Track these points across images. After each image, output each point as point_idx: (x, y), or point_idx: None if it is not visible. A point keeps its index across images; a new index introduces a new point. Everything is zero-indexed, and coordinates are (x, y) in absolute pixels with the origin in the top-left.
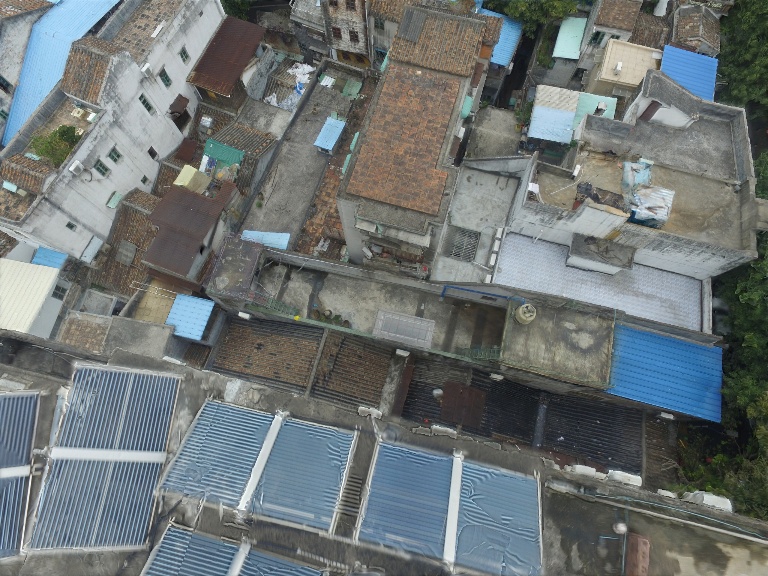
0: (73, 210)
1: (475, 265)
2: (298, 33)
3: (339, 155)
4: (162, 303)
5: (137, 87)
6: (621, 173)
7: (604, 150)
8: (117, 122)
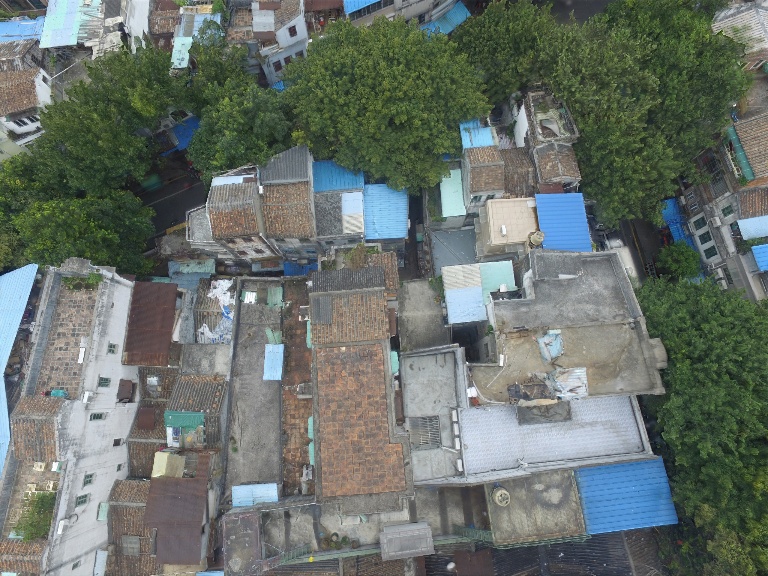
0: (73, 553)
1: (444, 450)
2: (203, 250)
3: (288, 373)
4: (182, 574)
5: (84, 415)
6: (538, 346)
7: None
8: (80, 456)
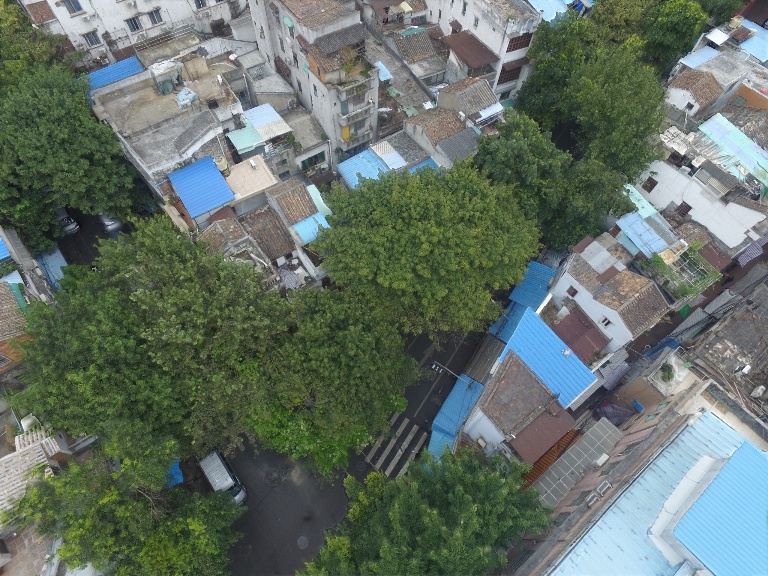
0: None
1: None
2: None
3: None
4: None
5: None
6: None
7: (215, 100)
8: None
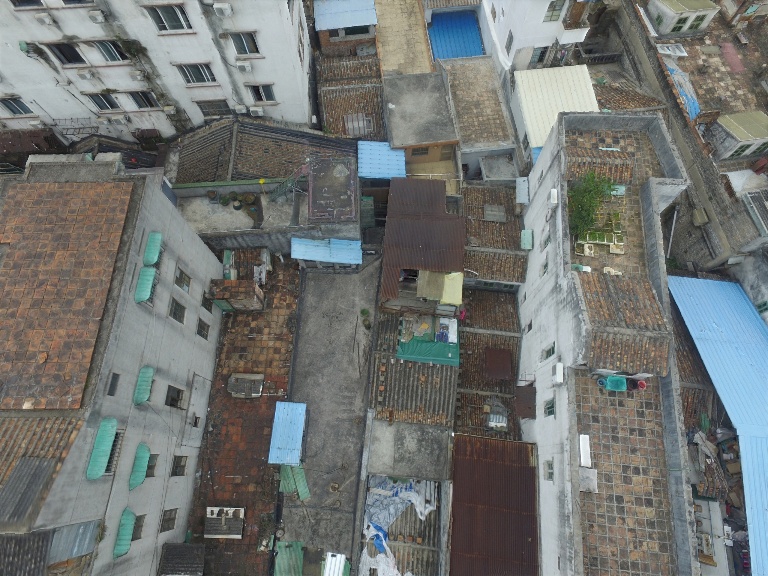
0: None
1: None
2: None
3: None
4: None
5: None
6: None
7: None
8: None
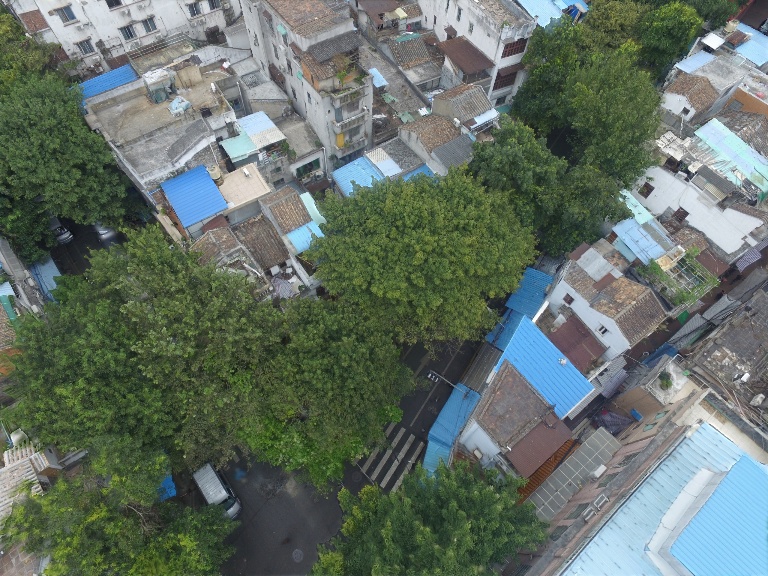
0: None
1: None
2: None
3: None
4: None
5: None
6: None
7: (209, 108)
8: None
